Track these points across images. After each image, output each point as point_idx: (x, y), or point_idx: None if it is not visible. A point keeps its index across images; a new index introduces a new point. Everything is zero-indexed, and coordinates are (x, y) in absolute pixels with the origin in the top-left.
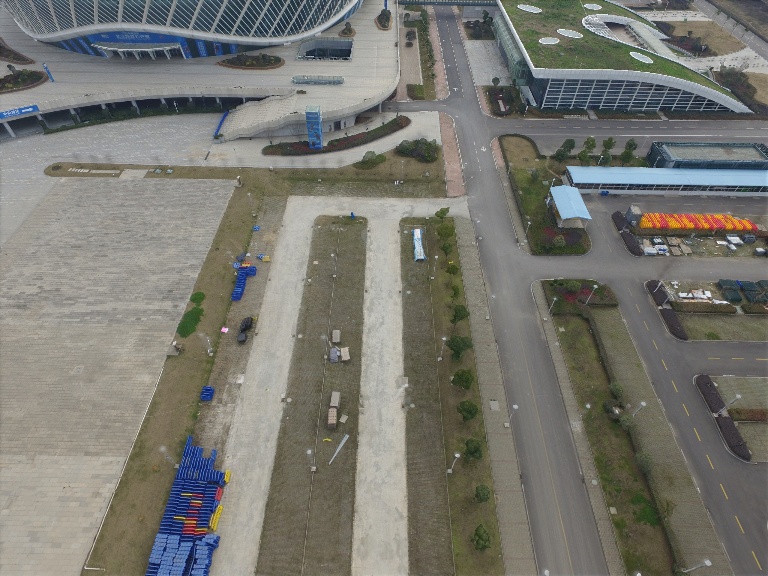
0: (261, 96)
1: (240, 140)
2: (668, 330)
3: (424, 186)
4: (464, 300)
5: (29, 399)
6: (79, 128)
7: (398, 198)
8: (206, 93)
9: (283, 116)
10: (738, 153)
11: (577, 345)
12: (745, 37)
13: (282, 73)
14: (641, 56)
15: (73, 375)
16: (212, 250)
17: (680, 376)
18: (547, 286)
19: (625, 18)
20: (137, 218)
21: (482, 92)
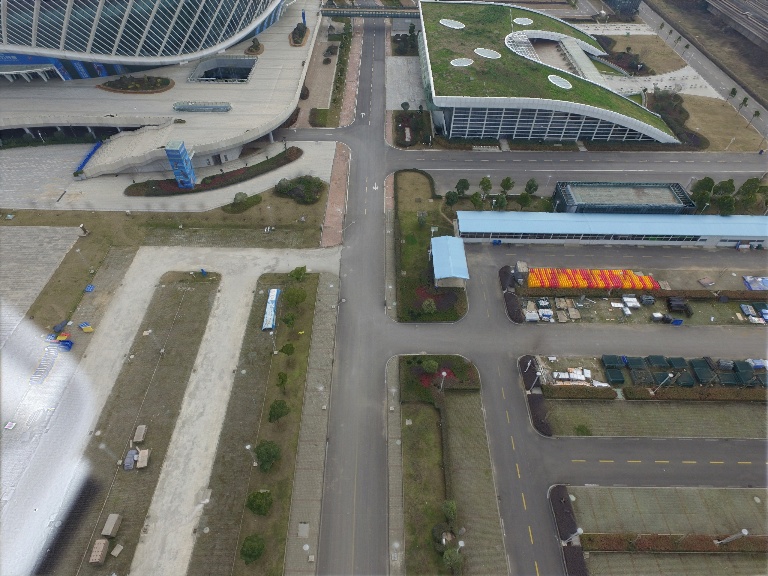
0: (136, 125)
1: (105, 177)
2: (532, 423)
3: (298, 233)
4: (303, 383)
5: None
6: None
7: (264, 248)
8: (74, 122)
9: (149, 151)
10: (649, 195)
11: (421, 444)
12: (688, 53)
13: (166, 98)
14: (560, 80)
15: None
16: (25, 319)
17: (533, 487)
18: (403, 364)
19: (557, 34)
20: None
21: (391, 118)
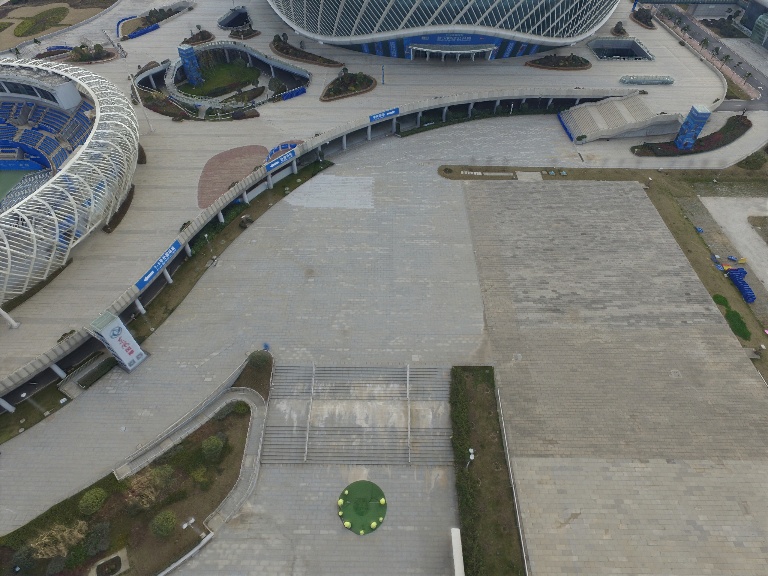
0: (598, 97)
1: (598, 141)
2: None
3: None
4: None
5: (658, 404)
6: (428, 131)
7: None
8: (544, 94)
9: (652, 117)
10: None
11: None
12: None
13: (600, 73)
14: None
15: (677, 379)
16: (686, 252)
17: None
18: None
19: None
20: (580, 221)
21: None
